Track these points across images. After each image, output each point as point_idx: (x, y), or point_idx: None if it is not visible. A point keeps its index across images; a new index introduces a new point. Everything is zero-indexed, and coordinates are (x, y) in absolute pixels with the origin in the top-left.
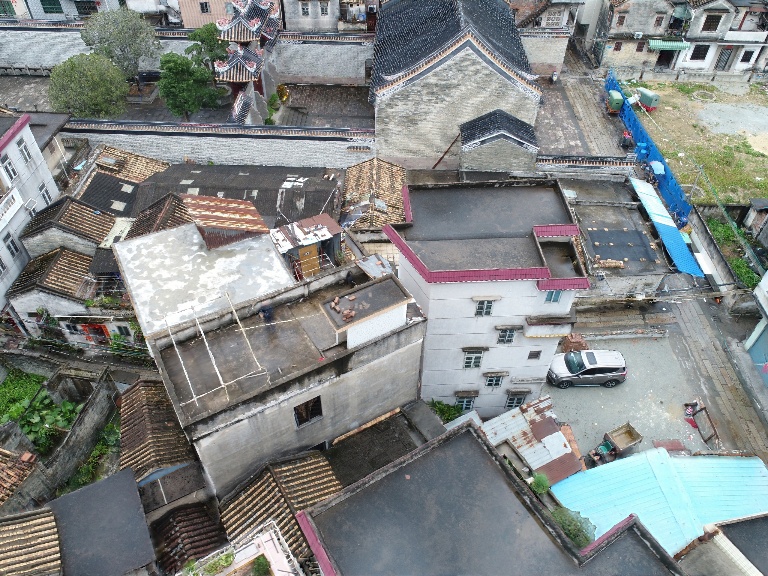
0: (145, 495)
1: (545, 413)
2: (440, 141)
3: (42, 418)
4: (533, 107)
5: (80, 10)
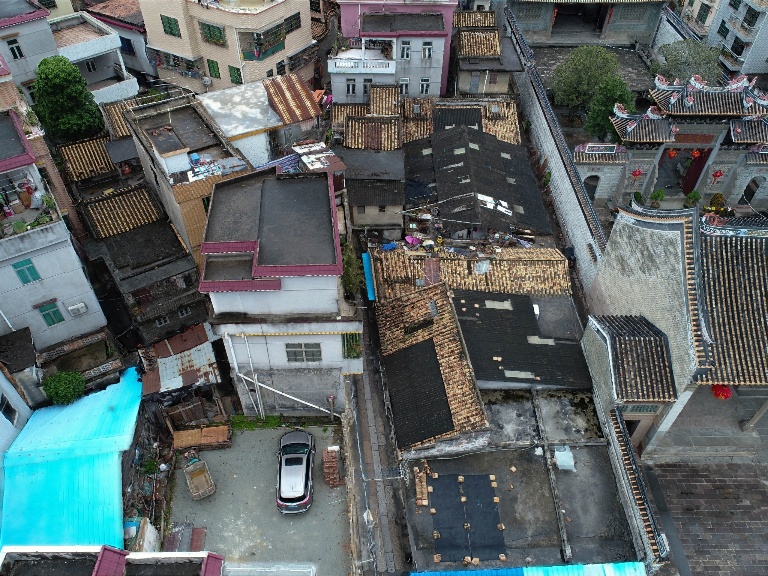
0: None
1: (203, 378)
2: (626, 314)
3: None
4: (688, 373)
5: (735, 44)
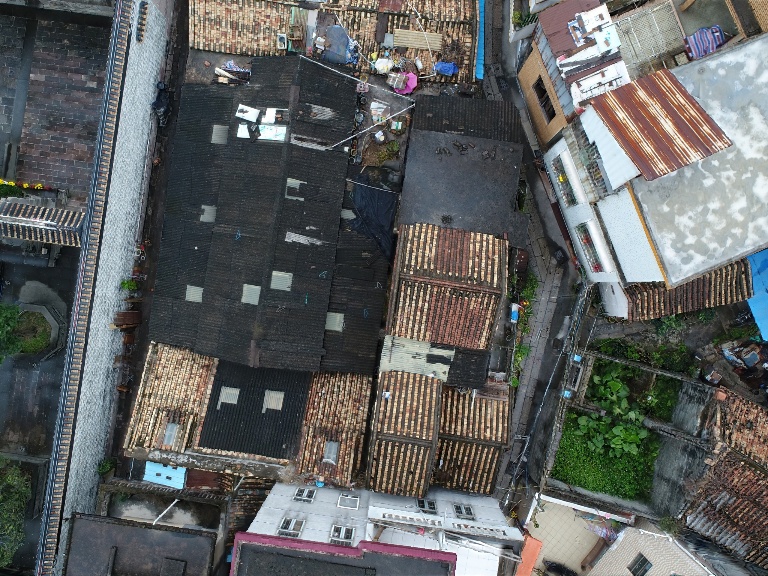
0: None
1: None
2: None
3: (627, 411)
4: None
5: None
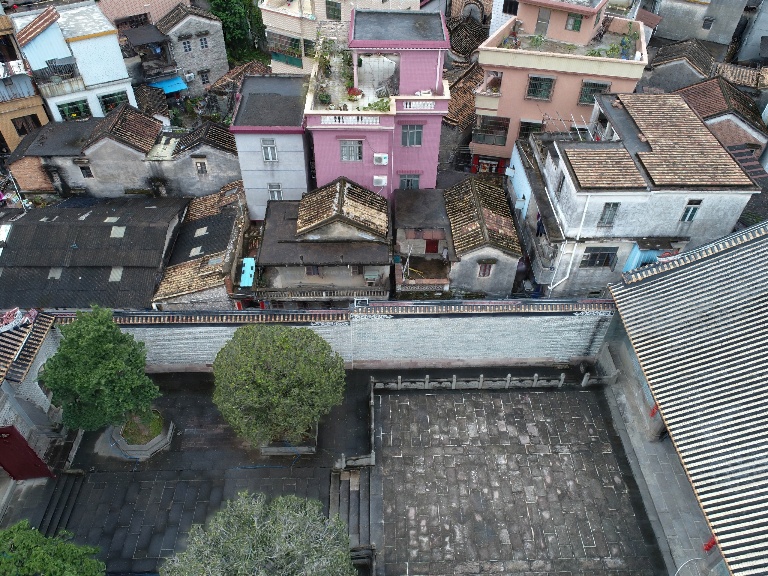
0: (131, 49)
1: None
2: None
3: None
4: None
5: None
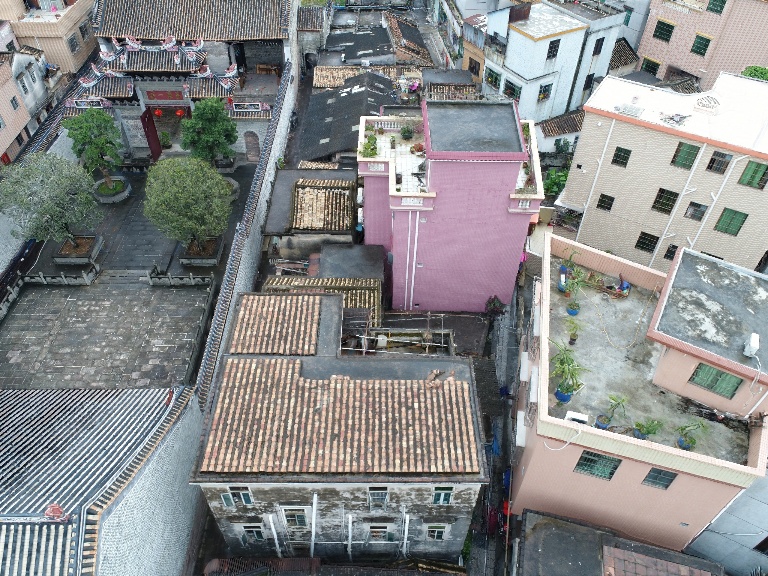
0: None
1: None
2: None
3: None
4: None
5: None
